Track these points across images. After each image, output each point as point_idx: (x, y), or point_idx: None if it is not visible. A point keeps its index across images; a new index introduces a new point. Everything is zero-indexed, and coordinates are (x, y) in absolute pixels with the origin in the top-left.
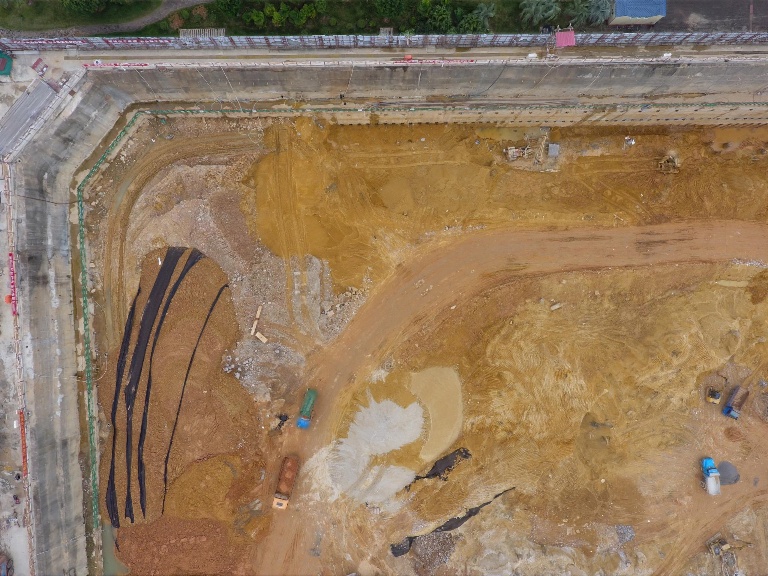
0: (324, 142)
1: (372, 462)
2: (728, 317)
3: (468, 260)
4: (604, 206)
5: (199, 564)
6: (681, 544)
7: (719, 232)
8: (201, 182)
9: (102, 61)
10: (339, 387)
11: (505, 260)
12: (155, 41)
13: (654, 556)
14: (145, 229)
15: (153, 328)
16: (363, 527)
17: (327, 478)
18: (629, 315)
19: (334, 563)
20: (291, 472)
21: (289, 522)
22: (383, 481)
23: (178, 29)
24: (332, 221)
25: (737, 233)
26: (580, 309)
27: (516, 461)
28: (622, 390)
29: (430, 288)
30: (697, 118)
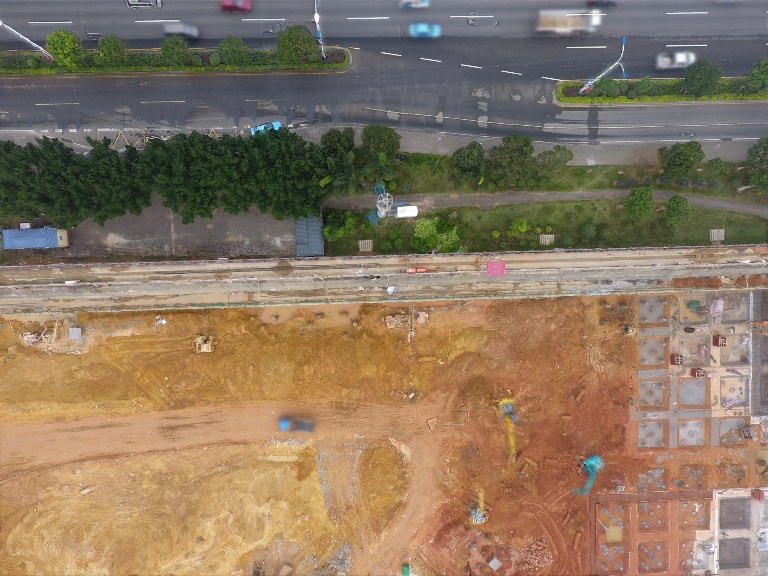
0: None
1: None
2: (264, 498)
3: None
4: (128, 390)
5: None
6: None
7: (251, 413)
8: None
9: None
10: None
11: (7, 454)
12: None
13: None
14: None
15: None
16: None
17: None
18: (173, 493)
19: None
20: None
21: None
22: None
23: None
24: None
25: (271, 413)
26: (117, 490)
27: None
28: (154, 575)
29: None
30: None
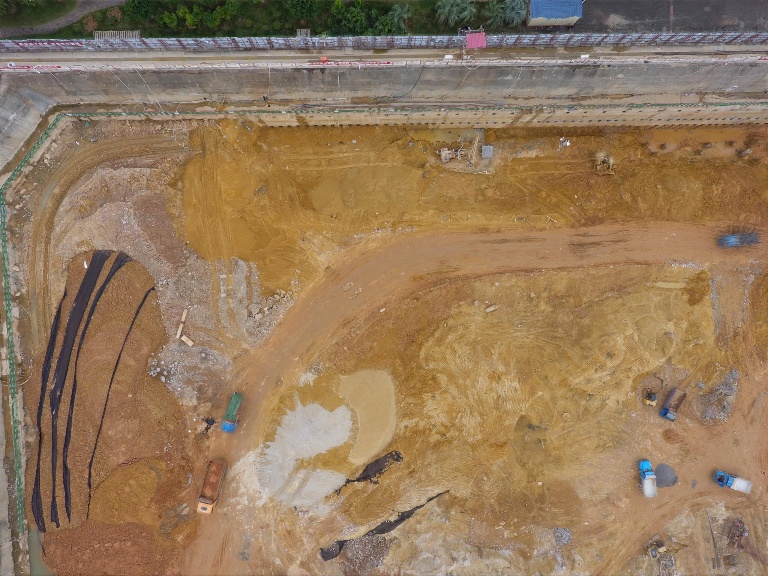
0: (254, 144)
1: (298, 466)
2: (664, 319)
3: (398, 262)
4: (538, 208)
5: (125, 569)
6: (619, 547)
7: (654, 233)
8: (125, 185)
9: (16, 64)
10: (266, 390)
11: (436, 262)
12: (66, 43)
13: (591, 559)
14: (70, 232)
15: (78, 332)
16: (292, 531)
17: (255, 482)
18: (566, 317)
19: (263, 567)
20: (216, 476)
21: (217, 526)
22: (310, 485)
23: (93, 31)
24: (260, 224)
25: (673, 234)
26: (516, 311)
27: (449, 464)
28: (557, 392)
29: (359, 291)
30: (629, 119)
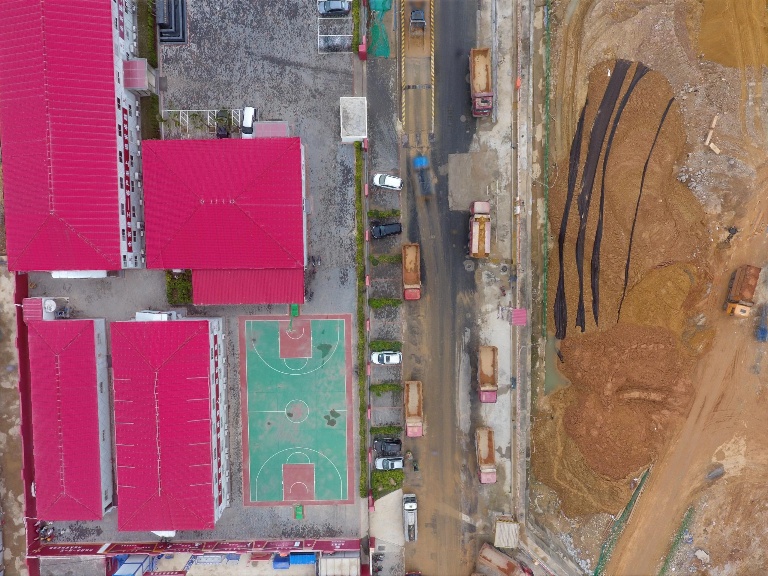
0: None
1: None
2: None
3: None
4: None
5: (650, 374)
6: None
7: None
8: None
9: None
10: None
11: None
12: None
13: None
14: (601, 38)
15: (605, 138)
16: None
17: None
18: None
19: None
20: (754, 279)
21: (731, 338)
22: None
23: None
24: None
25: None
26: None
27: None
28: None
29: None
30: None
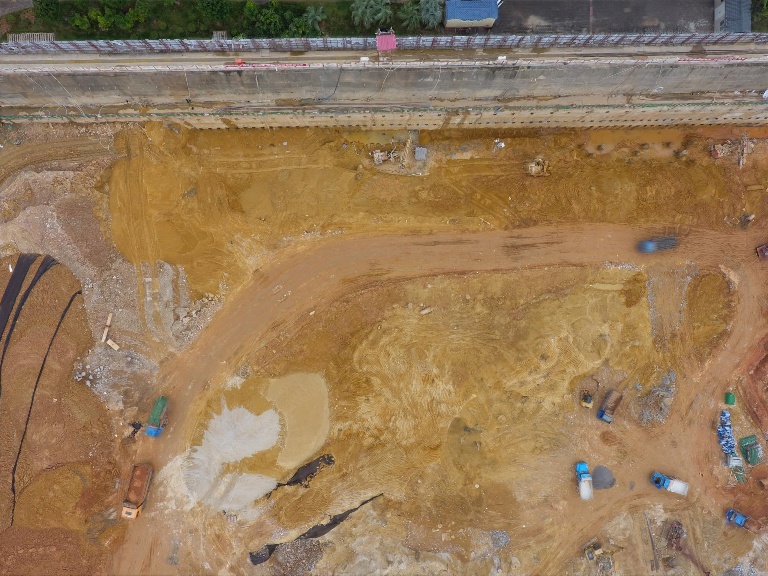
0: (183, 147)
1: (225, 470)
2: (599, 321)
3: (327, 265)
4: (472, 210)
5: (51, 574)
6: (557, 549)
7: (589, 235)
8: (49, 188)
9: None
10: (193, 394)
11: (367, 265)
12: None
13: (528, 561)
14: None
15: (3, 336)
16: (221, 535)
17: (182, 486)
18: (502, 319)
19: (192, 572)
20: (140, 481)
21: (145, 531)
22: (236, 489)
23: (6, 34)
24: (187, 227)
25: (608, 236)
26: (452, 313)
27: (382, 467)
28: (492, 395)
29: (288, 294)
30: (561, 120)
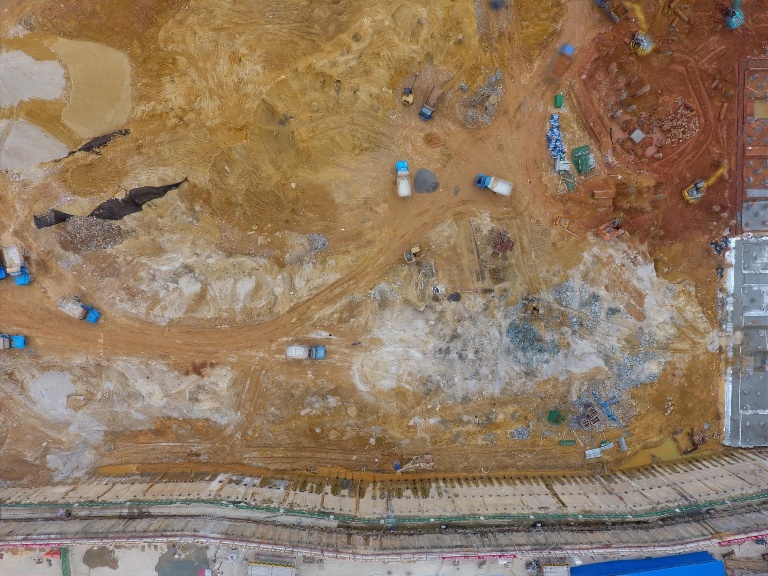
0: None
1: (1, 116)
2: None
3: None
4: None
5: None
6: (377, 255)
7: None
8: None
9: None
10: None
11: None
12: None
13: (345, 263)
14: None
15: None
16: (4, 196)
17: None
18: (322, 12)
19: None
20: None
21: None
22: (13, 137)
23: None
24: None
25: None
26: (267, 2)
27: (184, 145)
28: (305, 82)
29: None
30: None
